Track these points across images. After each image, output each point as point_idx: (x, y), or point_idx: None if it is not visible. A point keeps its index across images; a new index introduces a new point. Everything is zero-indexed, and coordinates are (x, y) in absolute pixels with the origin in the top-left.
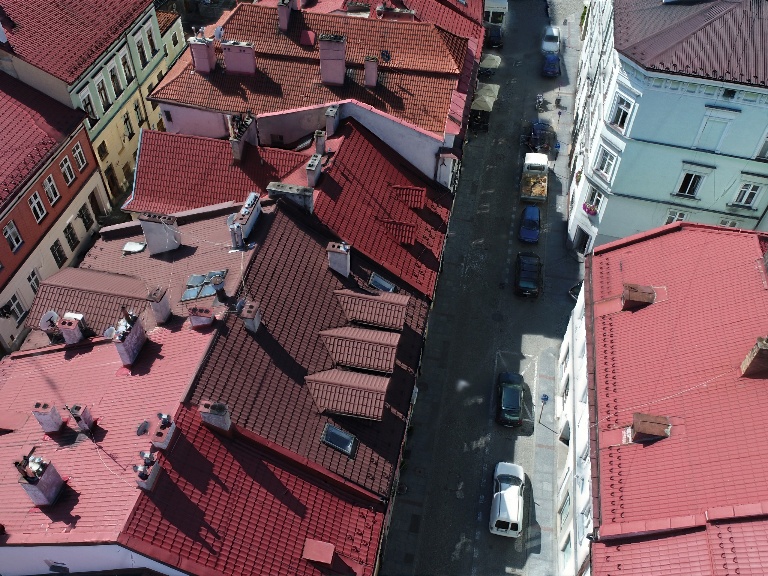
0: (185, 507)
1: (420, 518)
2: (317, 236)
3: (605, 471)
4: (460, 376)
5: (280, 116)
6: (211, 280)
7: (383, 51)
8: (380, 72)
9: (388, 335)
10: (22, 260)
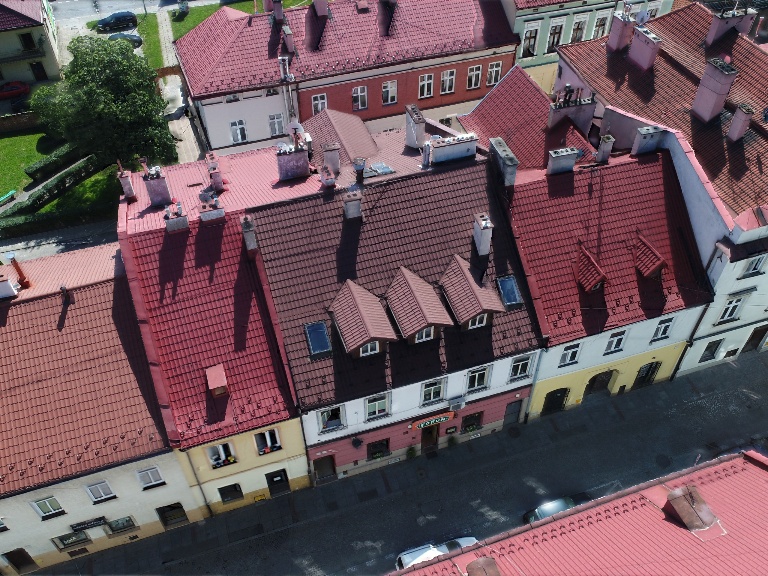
0: (177, 262)
1: (376, 496)
2: (496, 207)
3: (422, 571)
4: (554, 459)
5: (621, 115)
6: (357, 159)
7: (766, 108)
8: (755, 131)
9: (443, 315)
10: (387, 115)
